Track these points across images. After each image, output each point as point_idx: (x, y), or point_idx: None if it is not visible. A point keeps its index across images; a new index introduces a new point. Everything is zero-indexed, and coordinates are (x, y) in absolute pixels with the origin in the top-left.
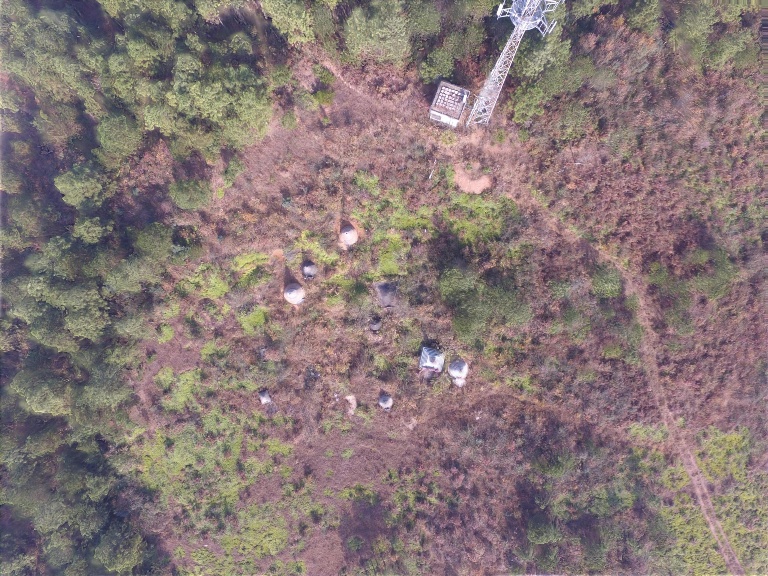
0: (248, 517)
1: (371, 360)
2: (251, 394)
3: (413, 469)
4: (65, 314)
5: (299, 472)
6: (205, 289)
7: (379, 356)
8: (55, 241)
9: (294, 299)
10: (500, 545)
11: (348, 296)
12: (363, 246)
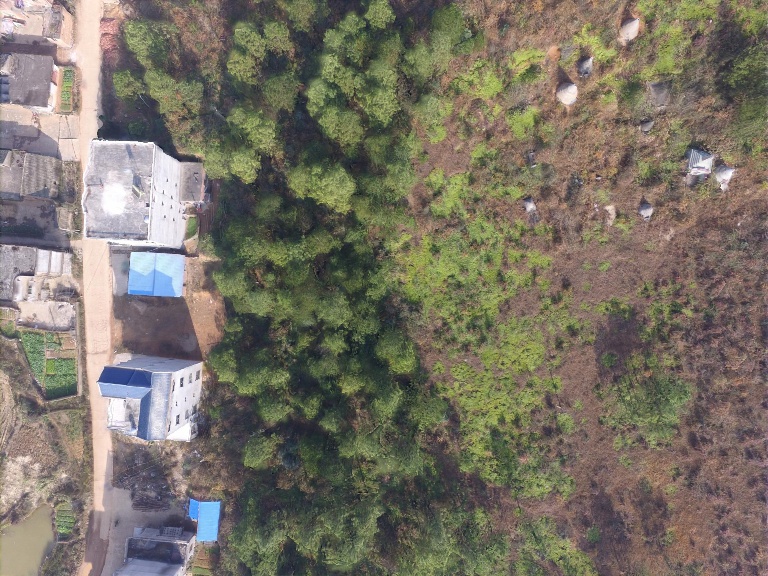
0: (508, 330)
1: (637, 165)
2: (514, 202)
3: (669, 281)
4: (353, 100)
5: (557, 285)
6: (478, 88)
7: (644, 161)
8: (352, 19)
9: (572, 96)
10: (759, 352)
11: (620, 97)
12: (643, 41)
